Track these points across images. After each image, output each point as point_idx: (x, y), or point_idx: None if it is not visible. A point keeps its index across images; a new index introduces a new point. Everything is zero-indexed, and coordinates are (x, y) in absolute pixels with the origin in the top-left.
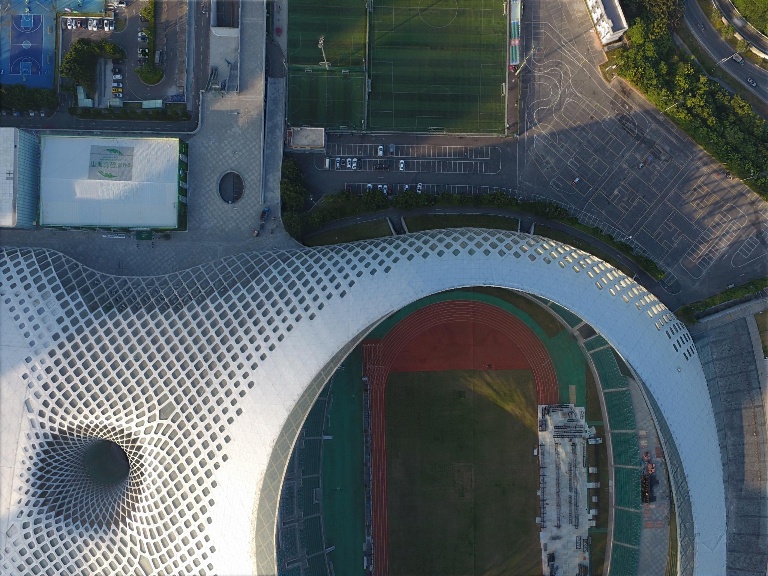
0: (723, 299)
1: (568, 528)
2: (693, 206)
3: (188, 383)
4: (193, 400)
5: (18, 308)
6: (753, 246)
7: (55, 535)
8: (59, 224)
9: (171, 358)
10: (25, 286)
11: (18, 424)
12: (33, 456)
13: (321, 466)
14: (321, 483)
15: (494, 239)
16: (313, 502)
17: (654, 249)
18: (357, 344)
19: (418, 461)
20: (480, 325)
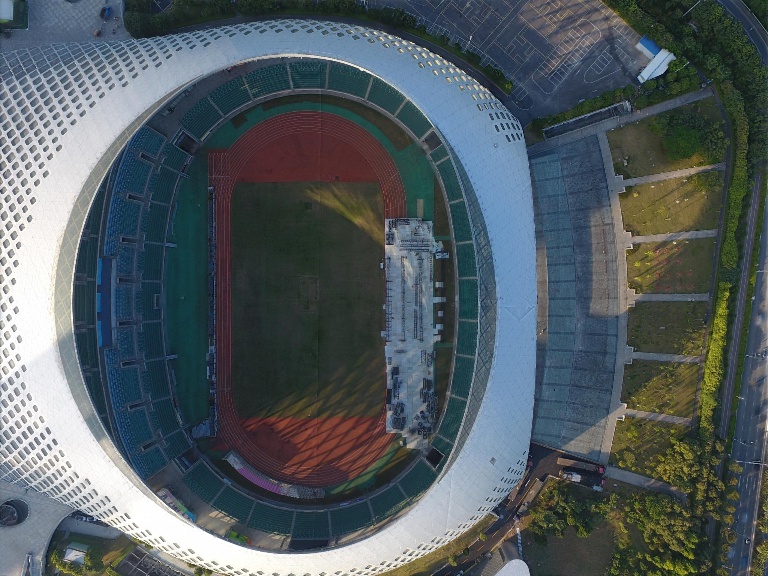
0: (574, 114)
1: (413, 342)
2: (546, 20)
3: None
4: (3, 166)
5: None
6: (606, 62)
7: None
8: None
9: None
10: None
11: None
12: None
13: (164, 274)
14: (164, 292)
15: (322, 24)
16: (153, 307)
17: (506, 63)
18: (163, 104)
19: (263, 272)
20: (328, 137)
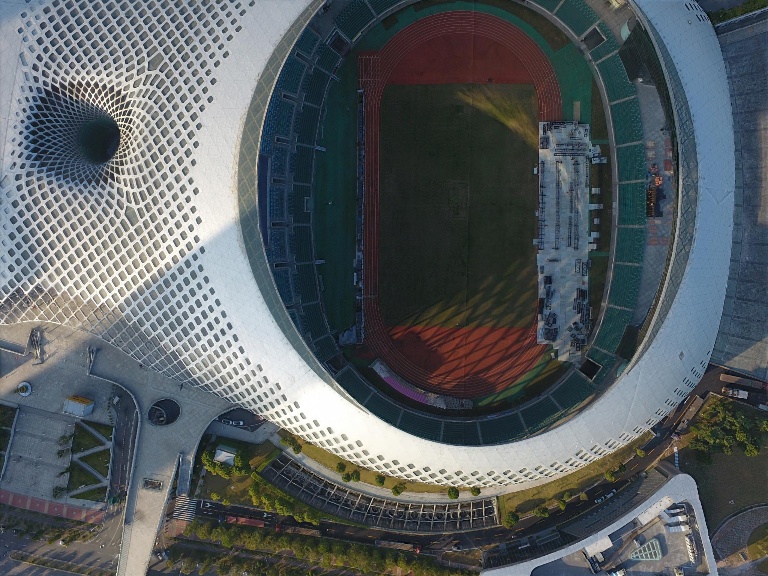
0: (745, 10)
1: (567, 251)
2: None
3: (177, 34)
4: (181, 50)
5: None
6: None
7: (46, 188)
8: None
9: (161, 13)
10: None
11: (13, 76)
12: (26, 109)
13: (313, 178)
14: (313, 196)
15: None
16: (304, 210)
17: None
18: None
19: (412, 177)
20: (481, 37)
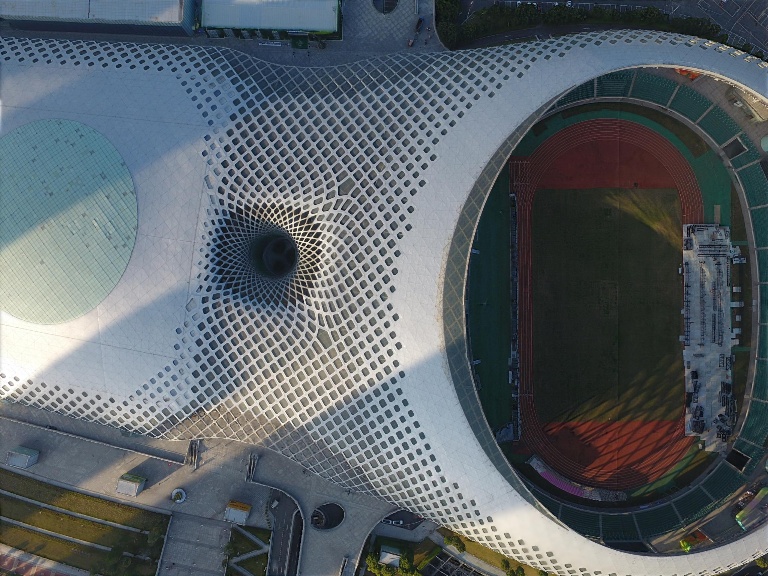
0: None
1: (711, 346)
2: None
3: (367, 160)
4: (373, 176)
5: (195, 90)
6: None
7: (233, 310)
8: (220, 26)
9: (348, 137)
10: (199, 71)
11: (198, 199)
12: (212, 232)
13: None
14: None
15: (662, 34)
16: None
17: None
18: None
19: (563, 278)
20: (626, 144)
